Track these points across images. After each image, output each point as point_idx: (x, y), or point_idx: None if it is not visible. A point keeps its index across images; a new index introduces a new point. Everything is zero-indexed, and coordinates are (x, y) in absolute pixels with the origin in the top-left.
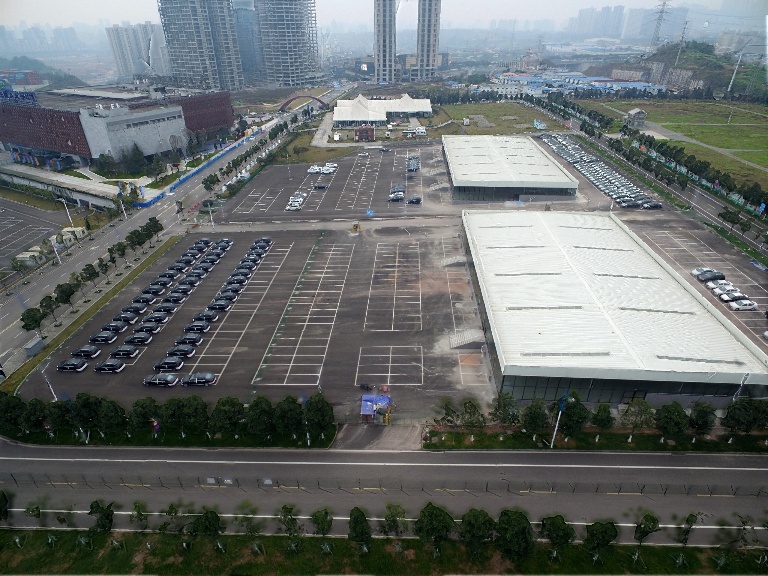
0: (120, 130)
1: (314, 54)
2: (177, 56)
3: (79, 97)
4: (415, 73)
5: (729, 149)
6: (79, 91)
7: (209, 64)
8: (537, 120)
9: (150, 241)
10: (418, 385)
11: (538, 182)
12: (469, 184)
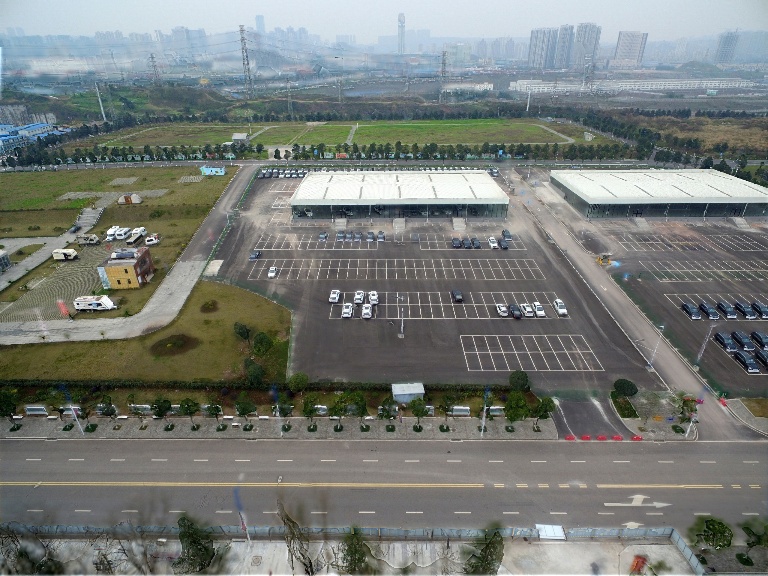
0: None
1: None
2: None
3: None
4: None
5: None
6: None
7: None
8: (206, 166)
9: None
10: None
11: None
12: None
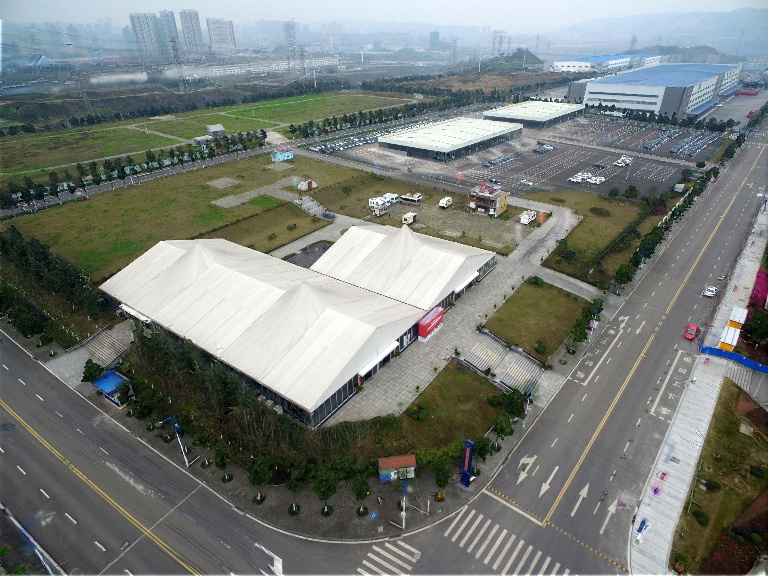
0: None
1: None
2: None
3: None
4: None
5: None
6: None
7: None
8: (279, 152)
9: None
10: None
11: None
12: None
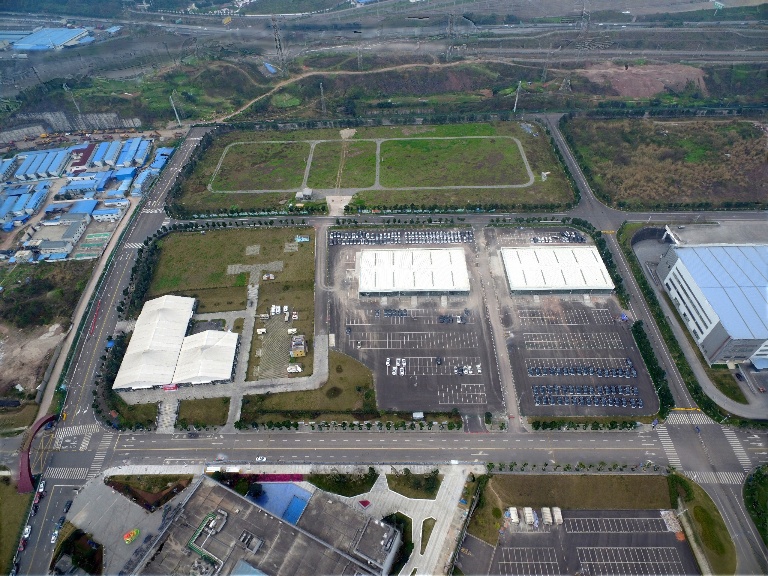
0: None
1: None
2: None
3: None
4: None
5: (376, 185)
6: None
7: None
8: (298, 237)
9: None
10: (609, 310)
11: None
12: None
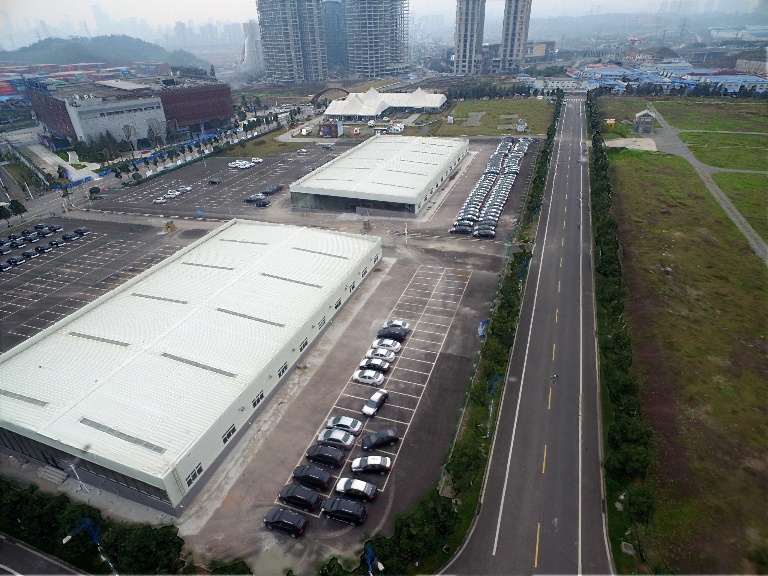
0: (93, 118)
1: (404, 45)
2: (268, 49)
3: (106, 87)
4: (497, 64)
5: (719, 168)
6: (114, 82)
7: (295, 56)
8: (520, 121)
9: (8, 221)
10: None
11: (372, 194)
12: (304, 190)
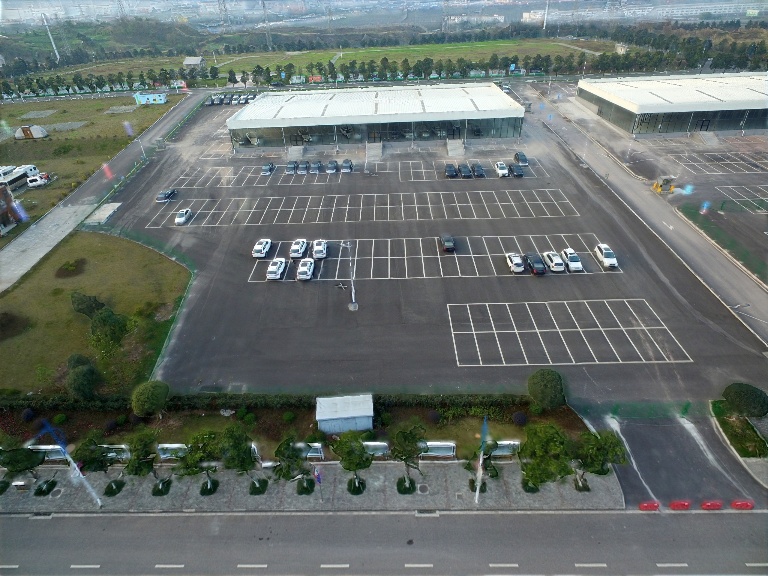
0: None
1: None
2: None
3: None
4: None
5: None
6: None
7: None
8: (141, 93)
9: None
10: None
11: None
12: None
